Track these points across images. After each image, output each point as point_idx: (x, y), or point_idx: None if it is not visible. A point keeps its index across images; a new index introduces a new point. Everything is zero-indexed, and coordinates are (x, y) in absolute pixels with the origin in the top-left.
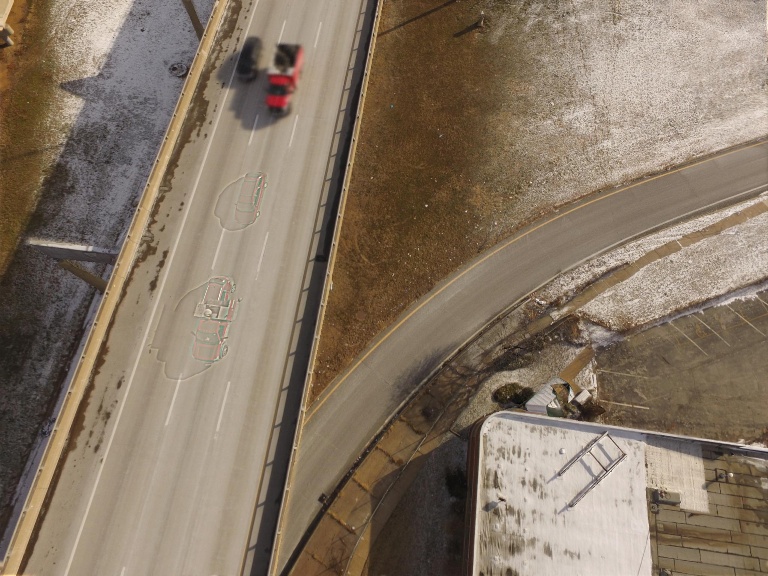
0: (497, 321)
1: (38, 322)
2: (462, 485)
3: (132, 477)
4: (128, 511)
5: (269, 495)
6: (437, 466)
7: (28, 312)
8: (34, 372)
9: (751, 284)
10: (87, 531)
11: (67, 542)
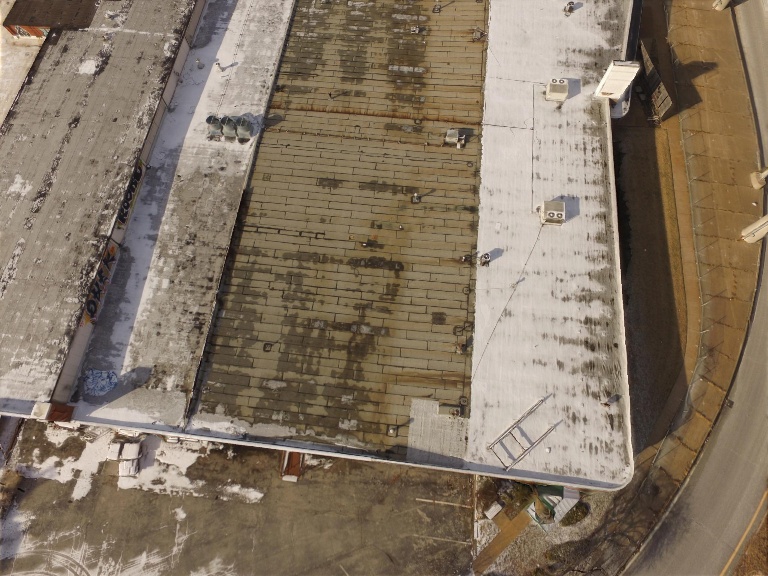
0: None
1: None
2: None
3: None
4: None
5: None
6: (637, 435)
7: None
8: None
9: None
10: None
11: None
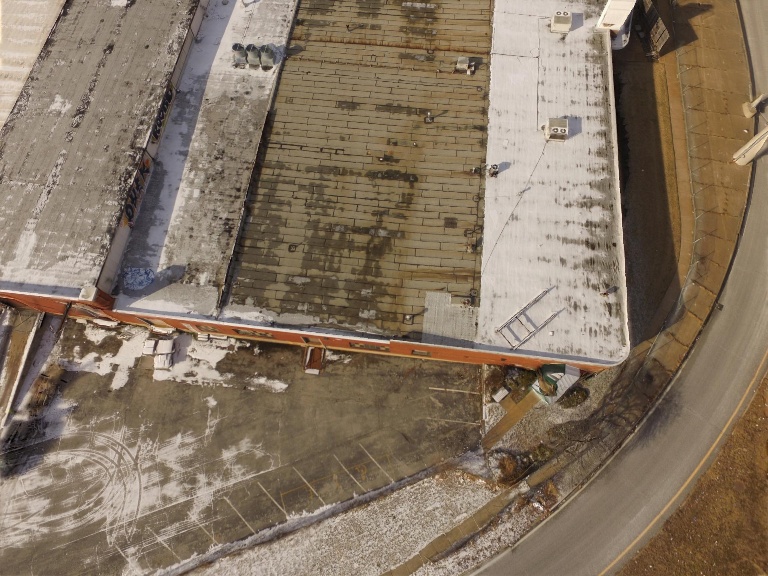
0: (585, 481)
1: None
2: None
3: None
4: None
5: None
6: (633, 331)
7: None
8: None
9: (291, 533)
10: None
11: None
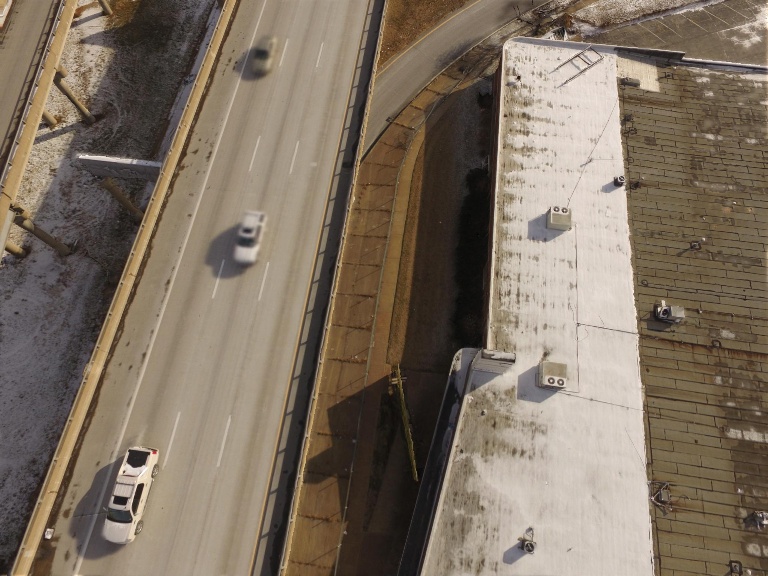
0: None
1: (174, 20)
2: (489, 98)
3: (286, 3)
4: (286, 17)
5: (374, 10)
6: (471, 95)
7: (167, 13)
8: (175, 47)
9: (699, 1)
10: (262, 25)
11: (250, 30)
